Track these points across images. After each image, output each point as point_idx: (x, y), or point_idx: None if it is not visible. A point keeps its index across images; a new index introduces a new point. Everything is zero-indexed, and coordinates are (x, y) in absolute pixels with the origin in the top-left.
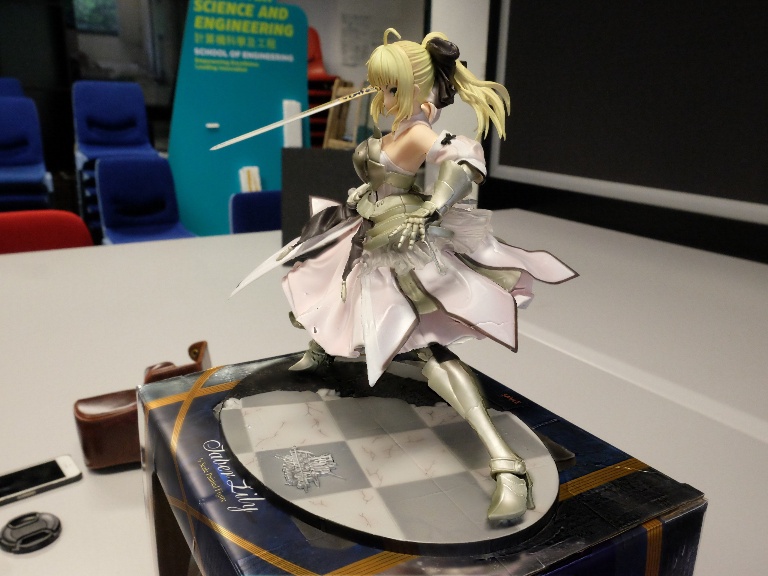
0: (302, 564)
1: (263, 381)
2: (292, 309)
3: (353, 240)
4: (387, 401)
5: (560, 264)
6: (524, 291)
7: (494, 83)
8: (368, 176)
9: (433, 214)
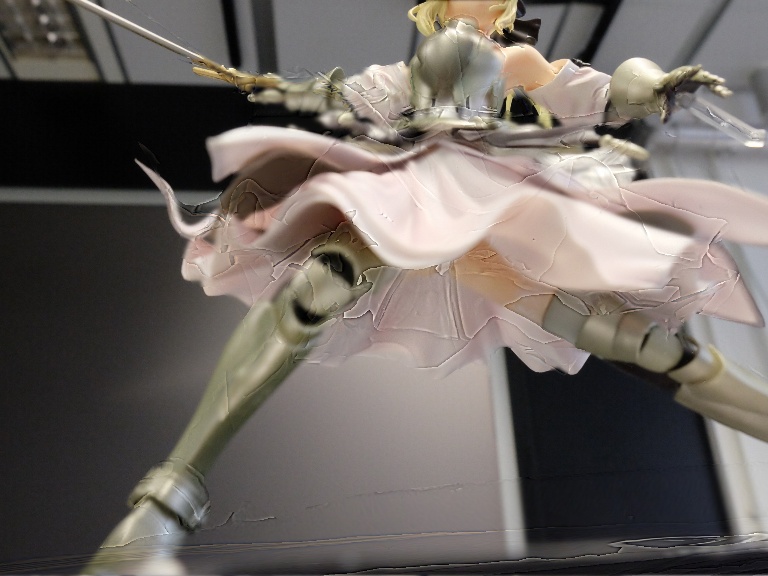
0: None
1: None
2: (417, 202)
3: (512, 118)
4: None
5: None
6: None
7: None
8: (467, 65)
9: None
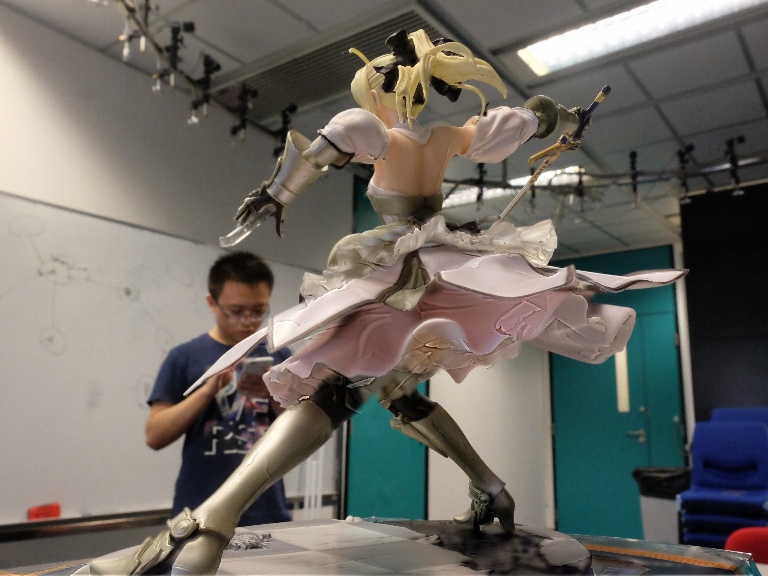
0: (55, 572)
1: (427, 526)
2: None
3: None
4: (454, 556)
5: (563, 274)
6: (459, 315)
7: (442, 44)
8: None
9: (262, 192)
